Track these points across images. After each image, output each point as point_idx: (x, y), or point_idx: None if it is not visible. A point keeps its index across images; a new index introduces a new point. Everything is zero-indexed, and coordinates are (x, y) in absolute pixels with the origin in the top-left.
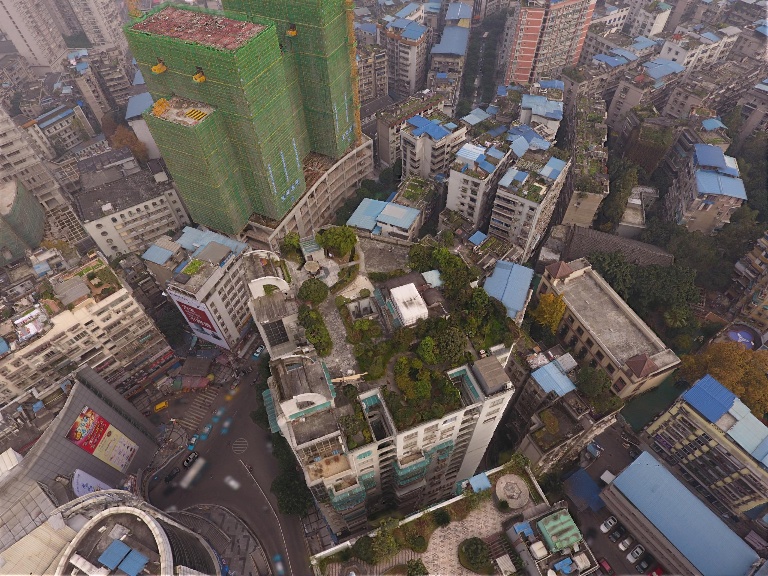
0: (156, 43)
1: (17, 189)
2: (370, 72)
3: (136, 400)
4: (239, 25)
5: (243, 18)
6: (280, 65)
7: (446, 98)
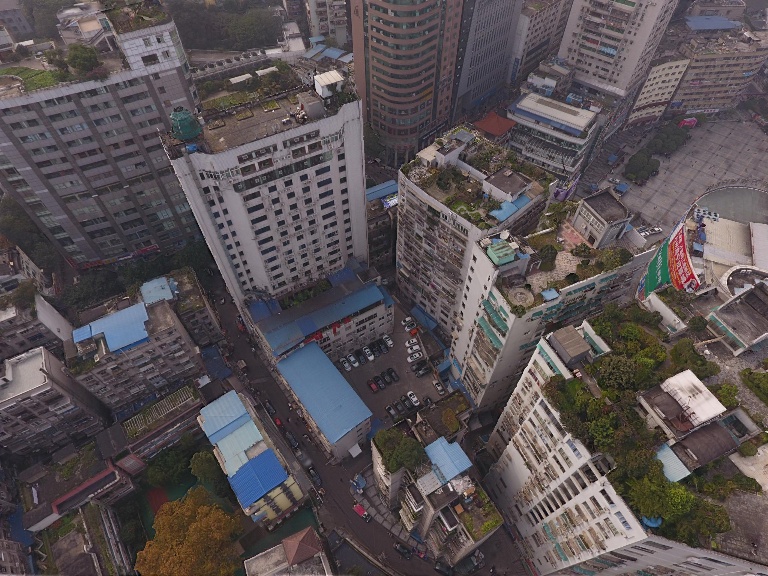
0: None
1: None
2: None
3: None
4: None
5: None
6: None
7: None
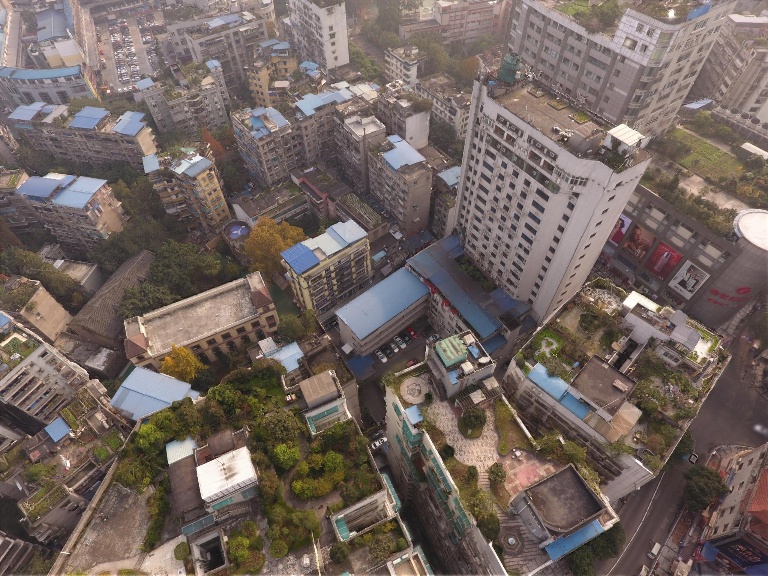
0: None
1: None
2: None
3: None
4: None
5: None
6: None
7: None
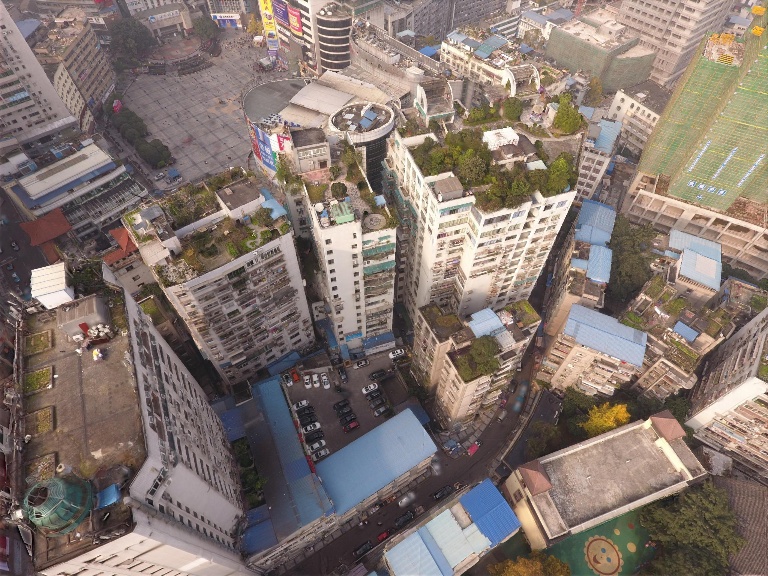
0: None
1: (646, 55)
2: None
3: None
4: None
5: None
6: None
7: None
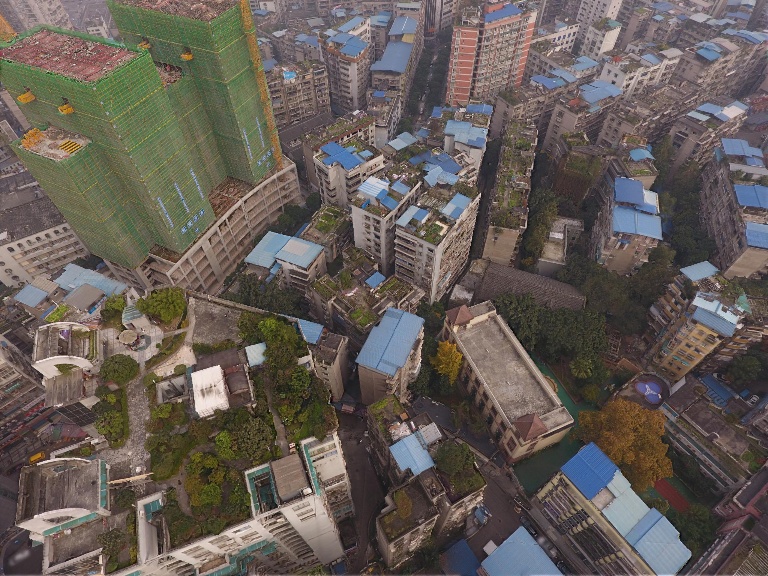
0: (18, 71)
1: None
2: (309, 88)
3: (13, 450)
4: (111, 52)
5: (139, 40)
6: (162, 94)
7: (381, 118)
